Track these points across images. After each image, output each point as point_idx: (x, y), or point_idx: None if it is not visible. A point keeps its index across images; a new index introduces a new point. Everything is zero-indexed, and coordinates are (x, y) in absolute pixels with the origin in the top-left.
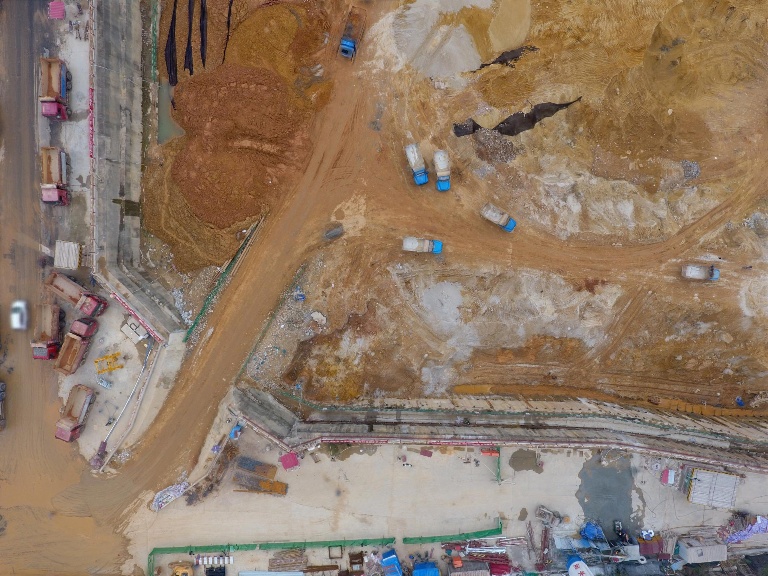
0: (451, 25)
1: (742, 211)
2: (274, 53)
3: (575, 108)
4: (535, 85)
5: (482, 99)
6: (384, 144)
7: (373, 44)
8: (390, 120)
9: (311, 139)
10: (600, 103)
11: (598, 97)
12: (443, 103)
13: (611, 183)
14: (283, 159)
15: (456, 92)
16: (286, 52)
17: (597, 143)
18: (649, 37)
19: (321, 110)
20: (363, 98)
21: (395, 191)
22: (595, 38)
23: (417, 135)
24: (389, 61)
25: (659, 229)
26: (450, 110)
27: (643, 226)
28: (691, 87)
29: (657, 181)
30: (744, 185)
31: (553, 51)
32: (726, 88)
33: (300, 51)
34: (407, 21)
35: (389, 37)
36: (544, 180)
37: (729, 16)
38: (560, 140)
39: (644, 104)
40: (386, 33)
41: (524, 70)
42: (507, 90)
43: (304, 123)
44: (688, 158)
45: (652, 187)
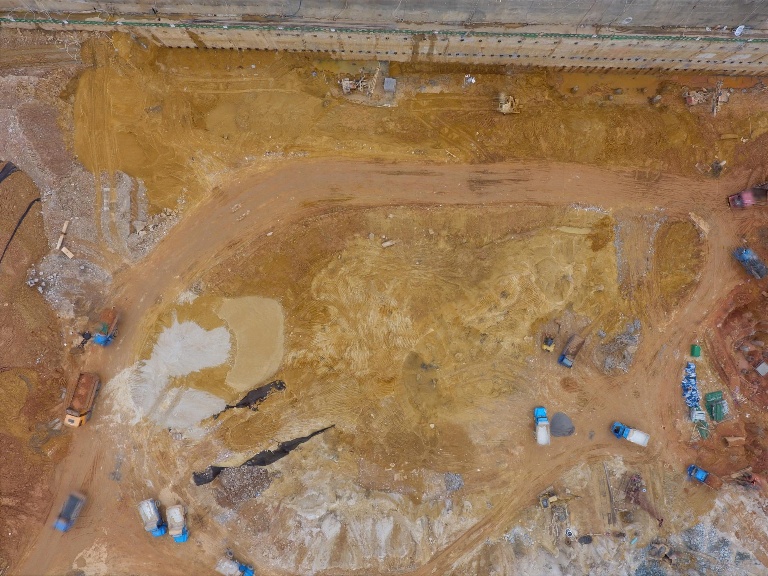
0: (181, 387)
1: (503, 525)
2: (3, 420)
3: (330, 434)
4: (281, 423)
5: (222, 446)
6: (124, 493)
7: (110, 399)
8: (130, 470)
9: (51, 490)
10: (354, 430)
11: (350, 426)
12: (182, 452)
13: (370, 503)
14: (23, 510)
15: (195, 442)
16: (17, 416)
17: (361, 457)
18: (399, 368)
19: (60, 462)
20: (102, 450)
21: (136, 538)
22: (346, 368)
23: (157, 484)
24: (126, 415)
25: (411, 557)
26: (189, 459)
27: (393, 556)
28: (450, 404)
29: (419, 496)
30: (507, 496)
31: (300, 388)
32: (489, 400)
33: (33, 412)
34: (142, 377)
35: (125, 392)
36: (299, 506)
37: (483, 339)
38: (321, 458)
39: (403, 423)
40: (122, 388)
41: (269, 411)
42: (251, 432)
43: (43, 475)
44: (451, 470)
45: (416, 499)
